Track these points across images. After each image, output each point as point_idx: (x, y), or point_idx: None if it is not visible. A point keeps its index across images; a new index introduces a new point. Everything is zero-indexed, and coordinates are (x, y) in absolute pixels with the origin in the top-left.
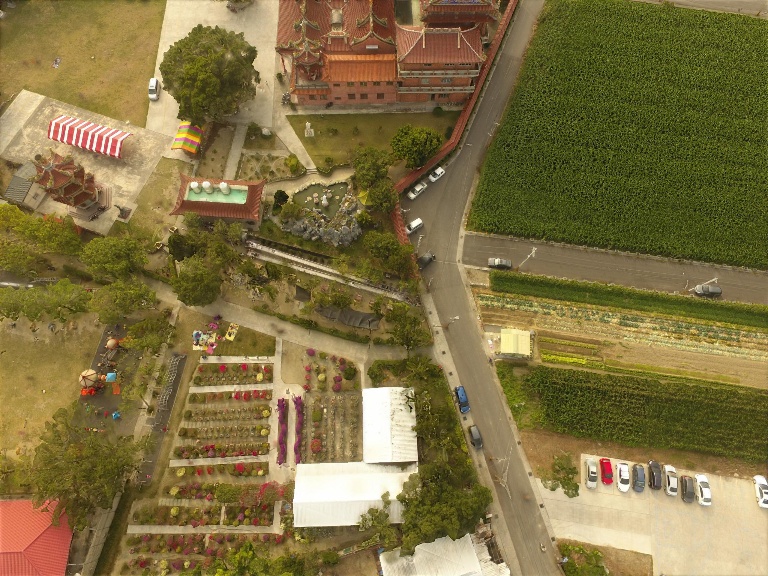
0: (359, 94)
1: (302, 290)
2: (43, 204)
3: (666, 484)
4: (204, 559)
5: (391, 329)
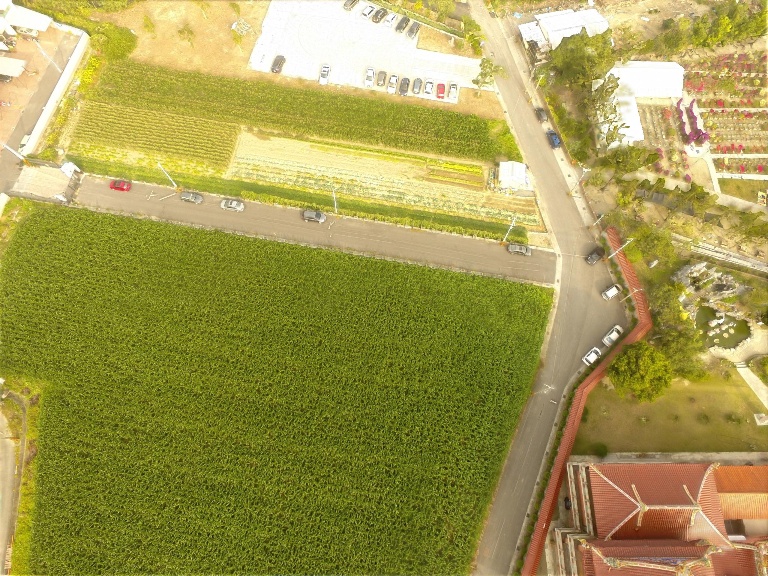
0: None
1: None
2: None
3: None
4: None
5: None
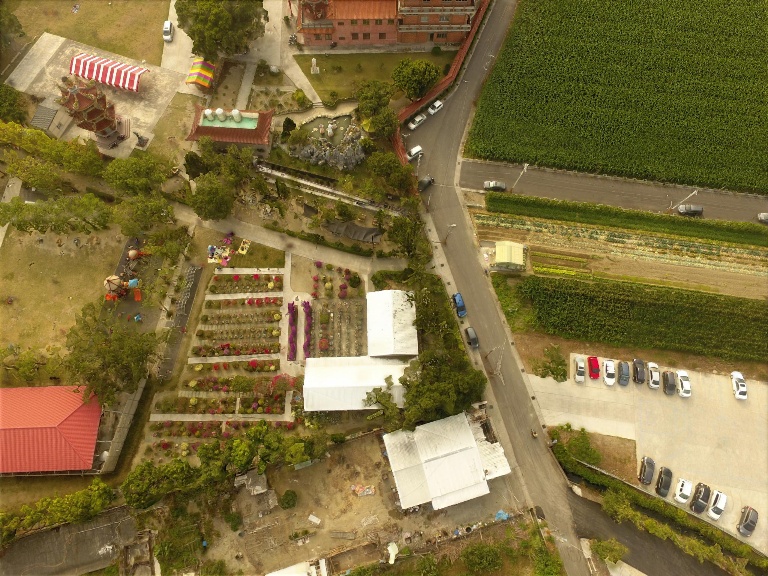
0: (362, 34)
1: (310, 208)
2: (66, 134)
3: (649, 378)
4: (221, 443)
5: (393, 244)
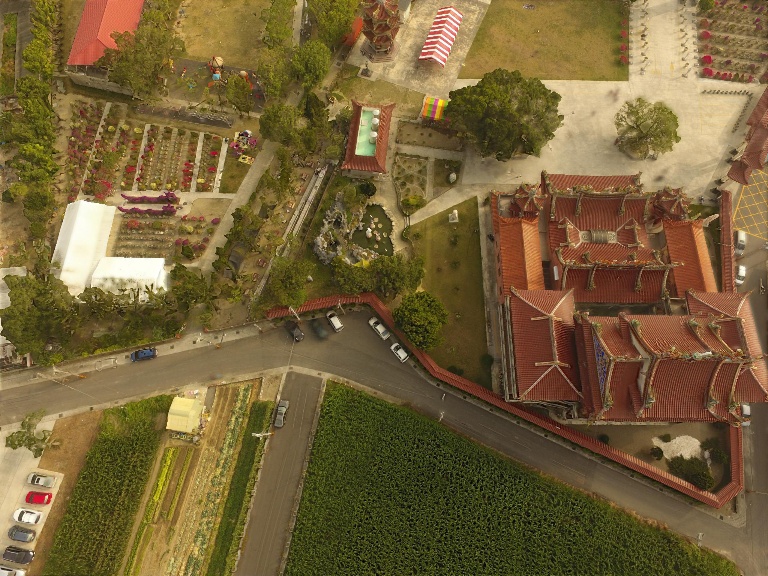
0: None
1: None
2: None
3: (5, 566)
4: None
5: None
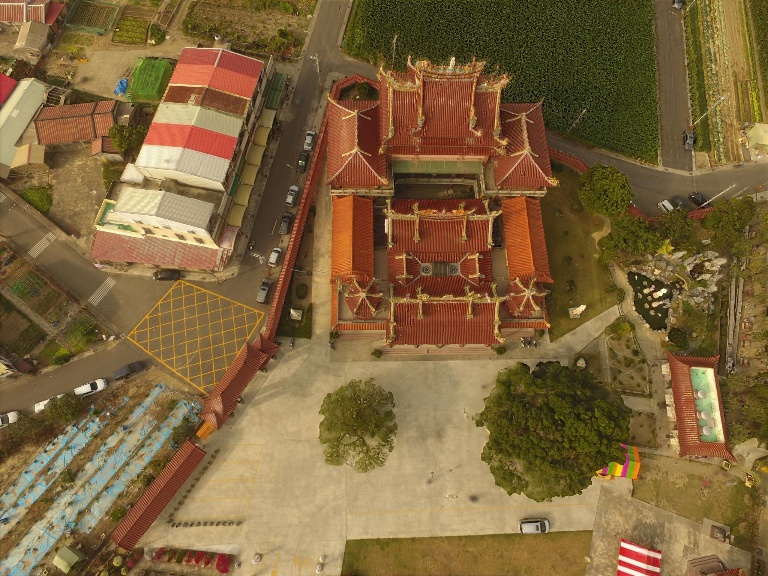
0: None
1: None
2: None
3: None
4: None
5: None
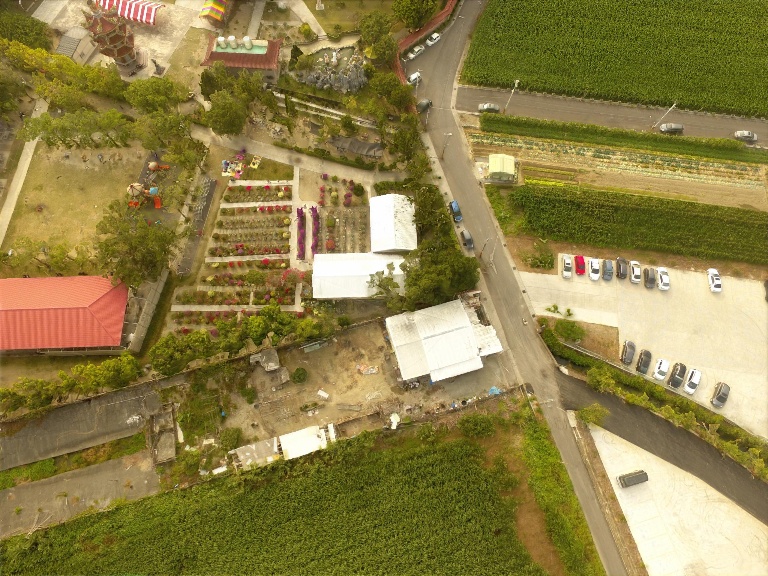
0: None
1: (316, 126)
2: None
3: (631, 273)
4: None
5: (394, 160)
